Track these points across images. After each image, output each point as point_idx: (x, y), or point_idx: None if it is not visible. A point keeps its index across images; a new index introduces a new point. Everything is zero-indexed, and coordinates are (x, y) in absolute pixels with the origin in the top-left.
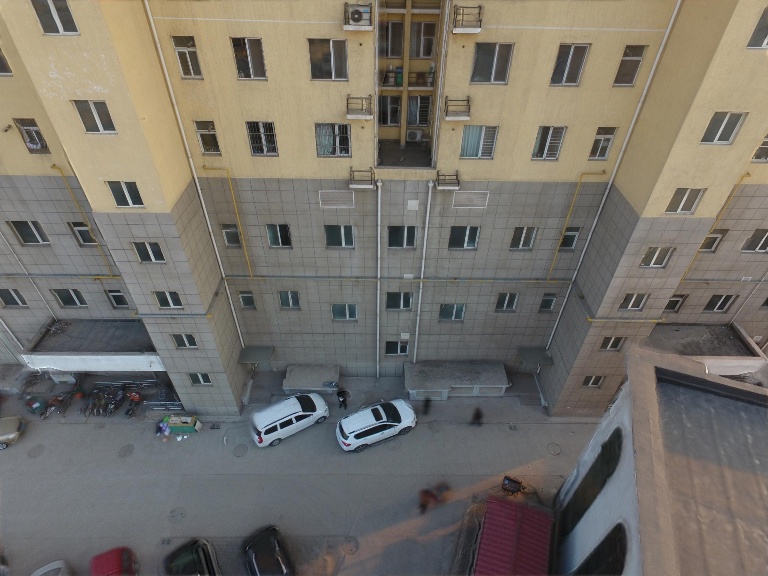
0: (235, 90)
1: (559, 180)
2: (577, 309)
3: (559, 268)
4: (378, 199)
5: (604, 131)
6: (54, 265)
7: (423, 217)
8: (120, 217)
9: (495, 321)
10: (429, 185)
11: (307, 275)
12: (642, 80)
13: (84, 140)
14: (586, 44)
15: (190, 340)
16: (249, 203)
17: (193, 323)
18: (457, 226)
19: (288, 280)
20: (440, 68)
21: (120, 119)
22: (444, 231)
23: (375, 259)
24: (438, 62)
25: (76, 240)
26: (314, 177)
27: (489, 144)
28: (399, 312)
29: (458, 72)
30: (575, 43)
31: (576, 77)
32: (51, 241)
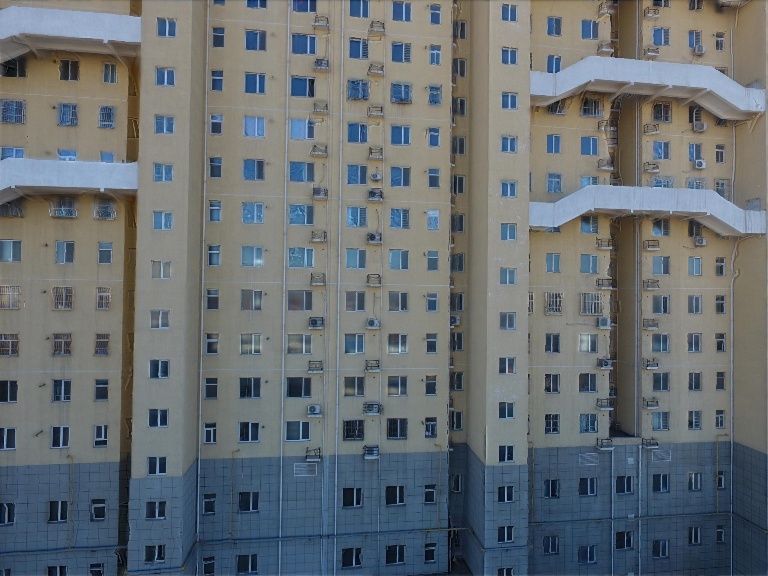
0: (543, 398)
1: (705, 441)
2: (746, 532)
3: (720, 503)
4: (612, 458)
5: (719, 412)
6: (400, 522)
7: (637, 469)
8: (499, 469)
9: (690, 555)
10: (639, 447)
11: (566, 520)
12: (728, 387)
13: (498, 422)
14: (699, 372)
15: (508, 575)
16: (538, 465)
17: (517, 555)
18: (656, 474)
19: (553, 525)
20: (635, 385)
21: (519, 411)
22: (649, 478)
23: (609, 503)
24: (633, 382)
25: (424, 499)
26: (577, 445)
27: (665, 422)
28: (625, 551)
29: (647, 386)
30: (694, 372)
31: (698, 387)
32: (408, 501)
